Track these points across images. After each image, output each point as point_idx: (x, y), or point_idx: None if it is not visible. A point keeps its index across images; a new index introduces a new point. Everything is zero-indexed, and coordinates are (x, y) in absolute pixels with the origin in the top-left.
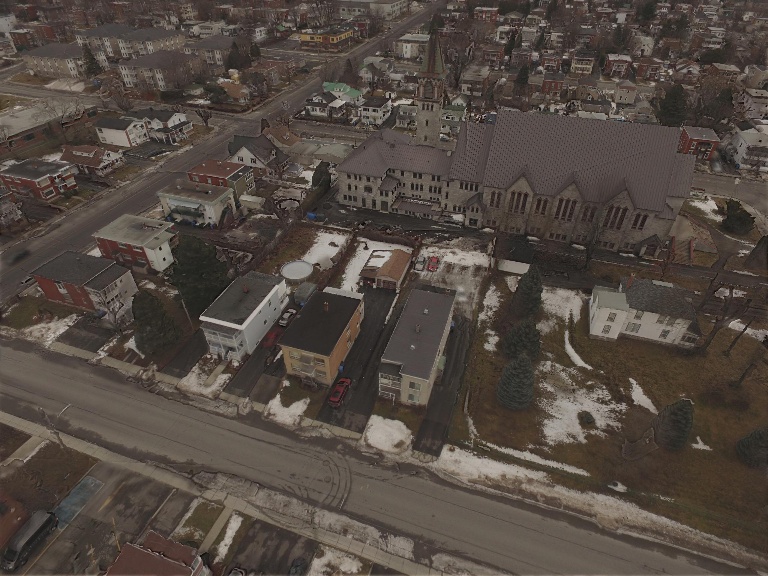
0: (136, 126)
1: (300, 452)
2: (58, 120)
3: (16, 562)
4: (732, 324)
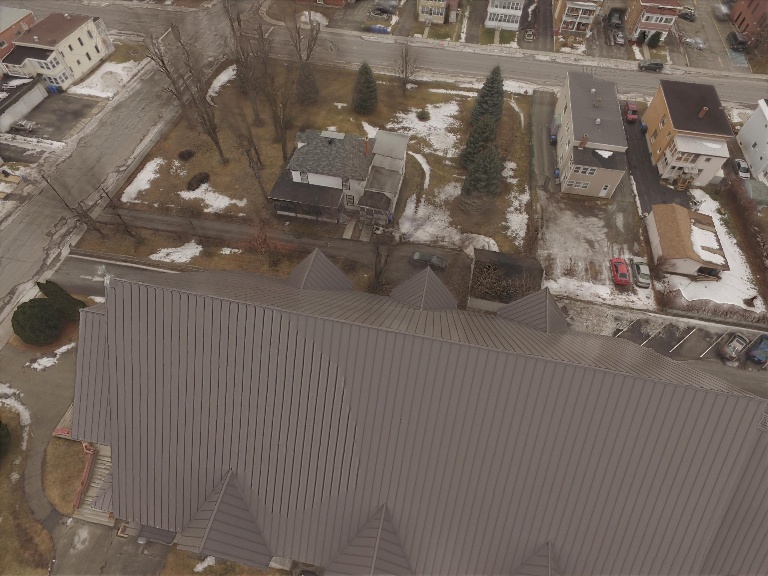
0: None
1: (630, 86)
2: None
3: None
4: (222, 202)
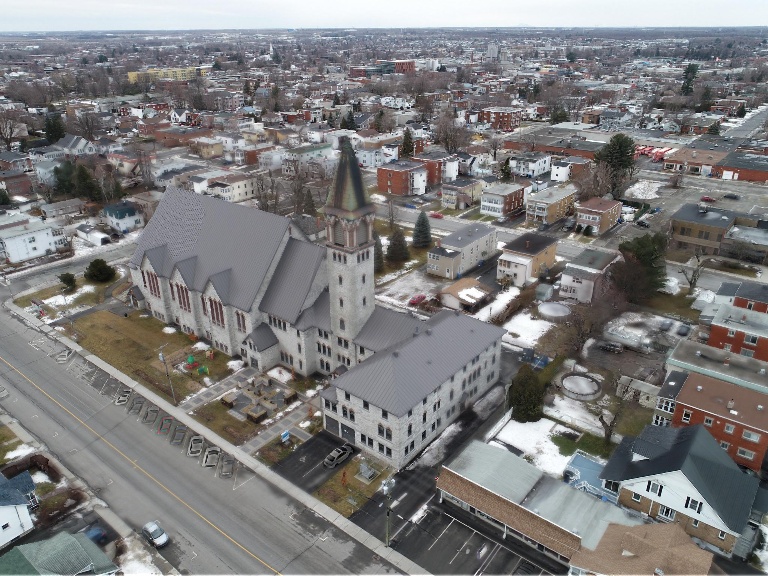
0: None
1: None
2: None
3: None
4: None
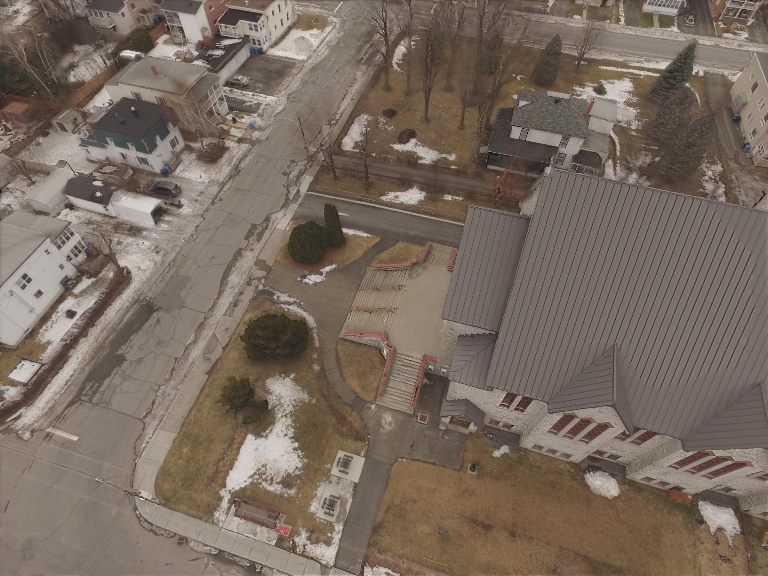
0: None
1: None
2: None
3: None
4: (434, 155)
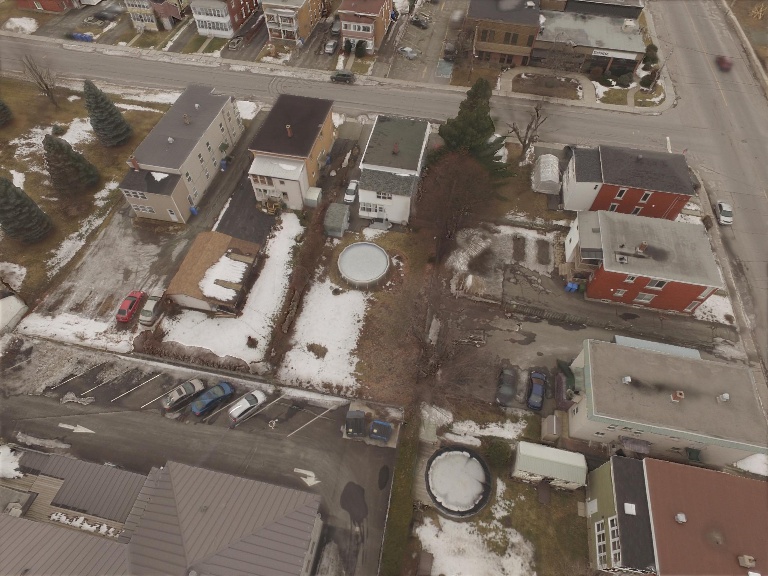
0: None
1: None
2: None
3: None
4: None
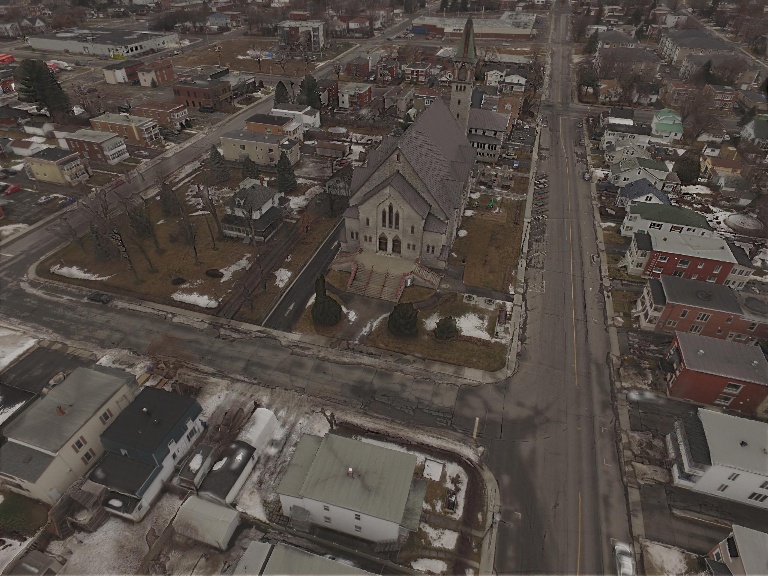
0: (495, 73)
1: None
2: (483, 58)
3: (199, 108)
4: (243, 262)
